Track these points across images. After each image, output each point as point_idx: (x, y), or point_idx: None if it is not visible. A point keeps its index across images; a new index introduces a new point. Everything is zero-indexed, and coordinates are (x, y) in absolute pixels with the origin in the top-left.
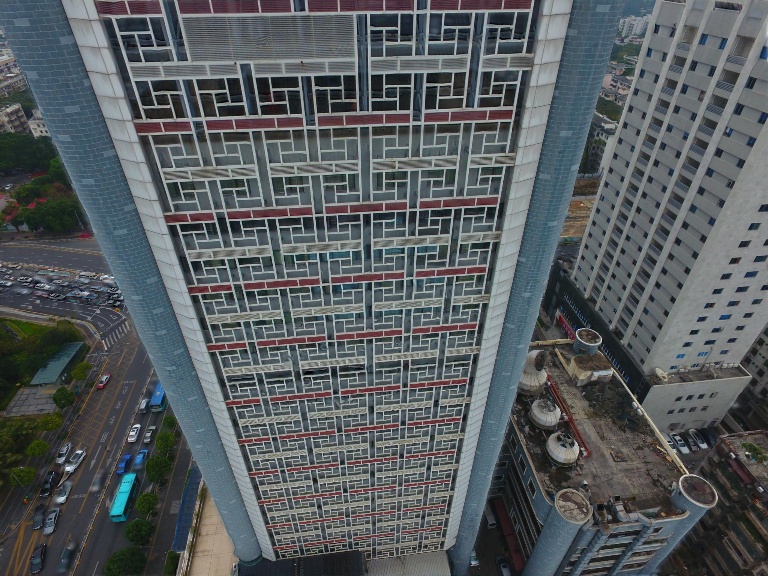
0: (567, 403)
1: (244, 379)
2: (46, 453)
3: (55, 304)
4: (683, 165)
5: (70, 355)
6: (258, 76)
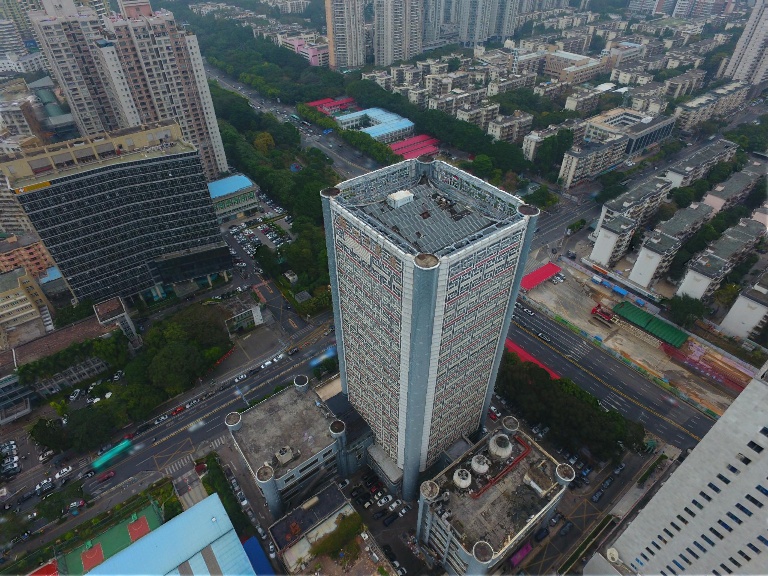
0: (505, 479)
1: None
2: None
3: None
4: None
5: None
6: (354, 252)
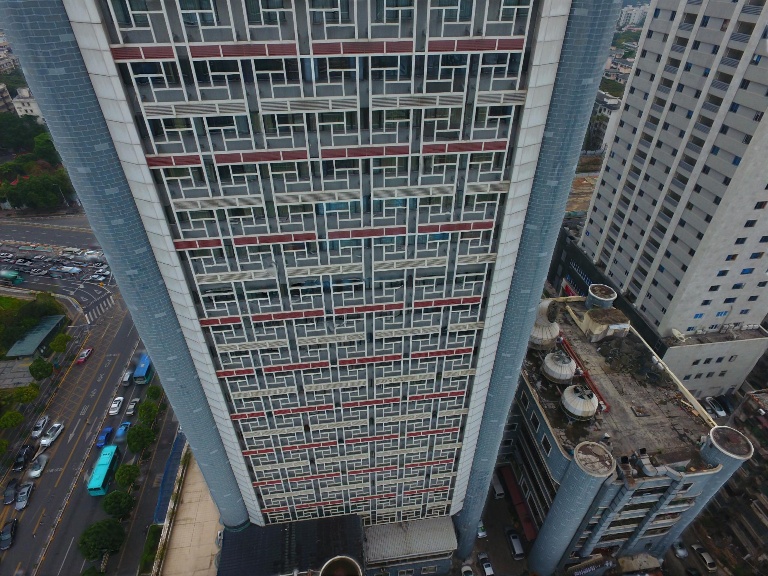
0: (581, 359)
1: (221, 291)
2: (21, 427)
3: (36, 279)
4: (703, 104)
5: (50, 327)
6: None
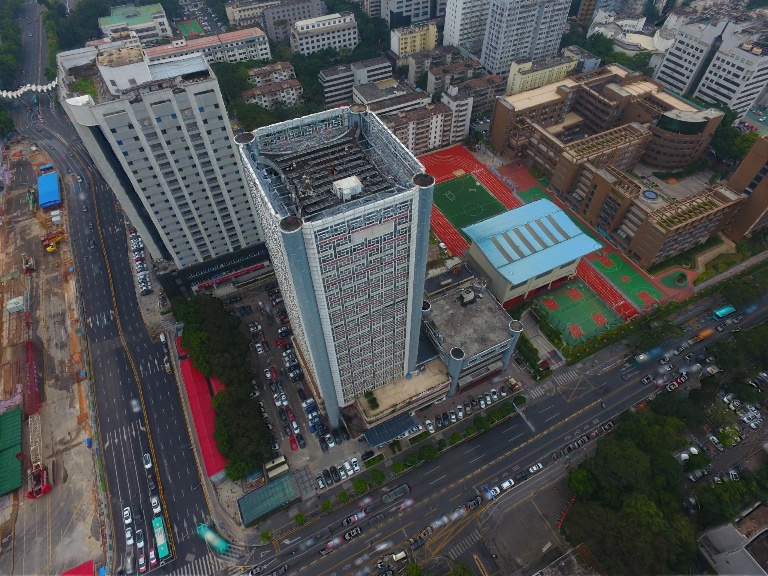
0: None
1: None
2: None
3: None
4: (201, 167)
5: None
6: None
